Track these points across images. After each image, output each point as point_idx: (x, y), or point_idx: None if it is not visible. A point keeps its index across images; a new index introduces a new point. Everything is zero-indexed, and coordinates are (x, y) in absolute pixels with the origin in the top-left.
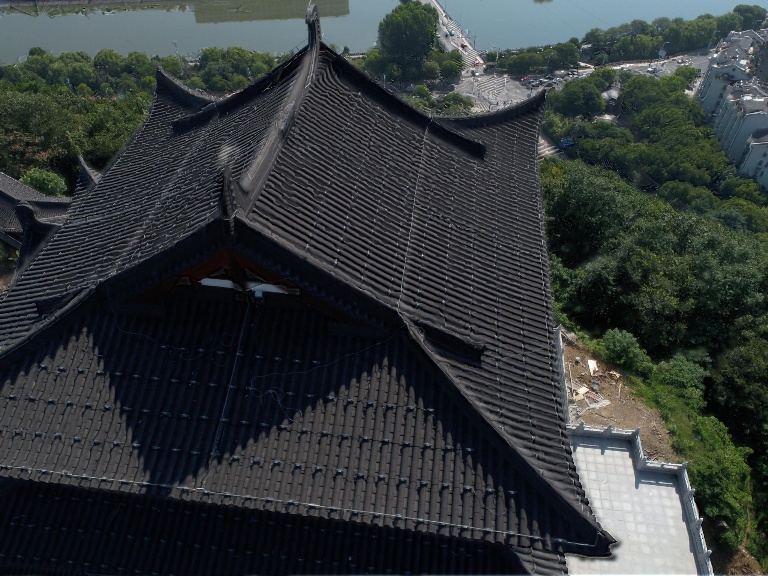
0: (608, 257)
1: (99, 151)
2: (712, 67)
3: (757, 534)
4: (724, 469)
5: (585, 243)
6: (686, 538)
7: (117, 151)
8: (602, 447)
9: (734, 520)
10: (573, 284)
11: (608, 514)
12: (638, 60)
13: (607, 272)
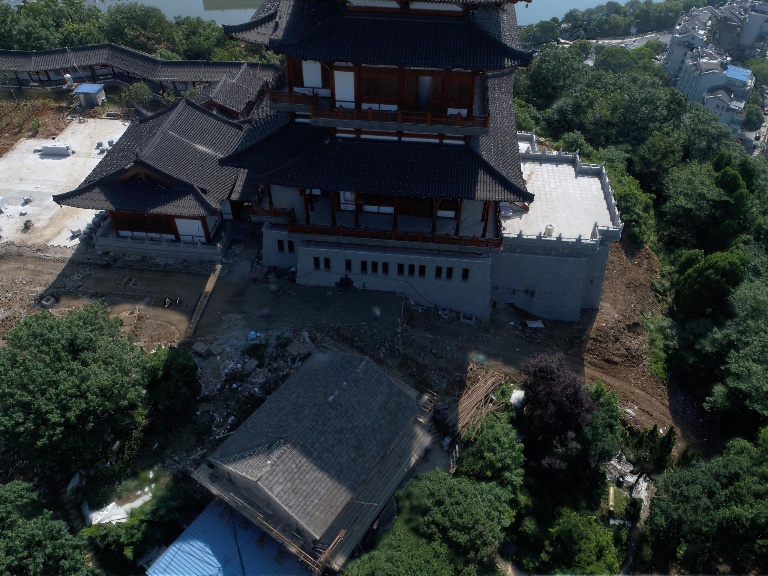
0: (567, 98)
1: (195, 49)
2: (674, 36)
3: (657, 243)
4: (634, 194)
5: (553, 100)
6: (602, 195)
7: (208, 49)
8: (557, 164)
9: (640, 224)
10: (544, 118)
11: (559, 187)
12: (612, 37)
13: (566, 106)
